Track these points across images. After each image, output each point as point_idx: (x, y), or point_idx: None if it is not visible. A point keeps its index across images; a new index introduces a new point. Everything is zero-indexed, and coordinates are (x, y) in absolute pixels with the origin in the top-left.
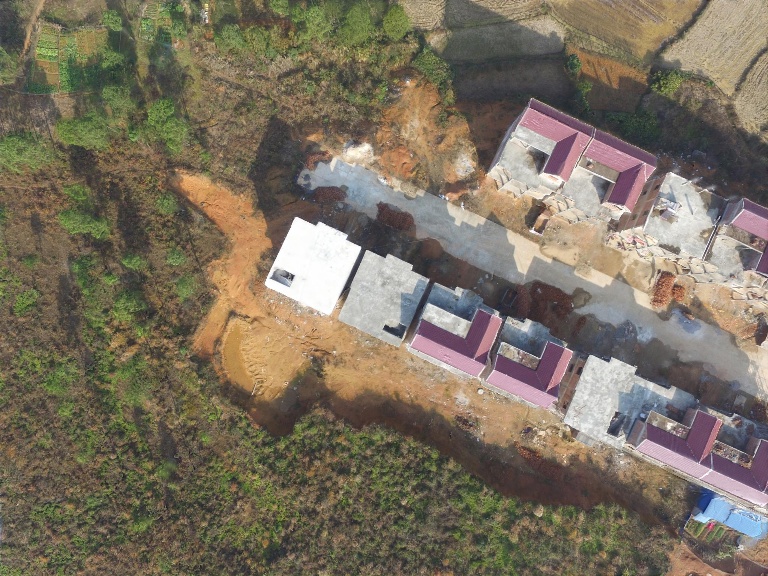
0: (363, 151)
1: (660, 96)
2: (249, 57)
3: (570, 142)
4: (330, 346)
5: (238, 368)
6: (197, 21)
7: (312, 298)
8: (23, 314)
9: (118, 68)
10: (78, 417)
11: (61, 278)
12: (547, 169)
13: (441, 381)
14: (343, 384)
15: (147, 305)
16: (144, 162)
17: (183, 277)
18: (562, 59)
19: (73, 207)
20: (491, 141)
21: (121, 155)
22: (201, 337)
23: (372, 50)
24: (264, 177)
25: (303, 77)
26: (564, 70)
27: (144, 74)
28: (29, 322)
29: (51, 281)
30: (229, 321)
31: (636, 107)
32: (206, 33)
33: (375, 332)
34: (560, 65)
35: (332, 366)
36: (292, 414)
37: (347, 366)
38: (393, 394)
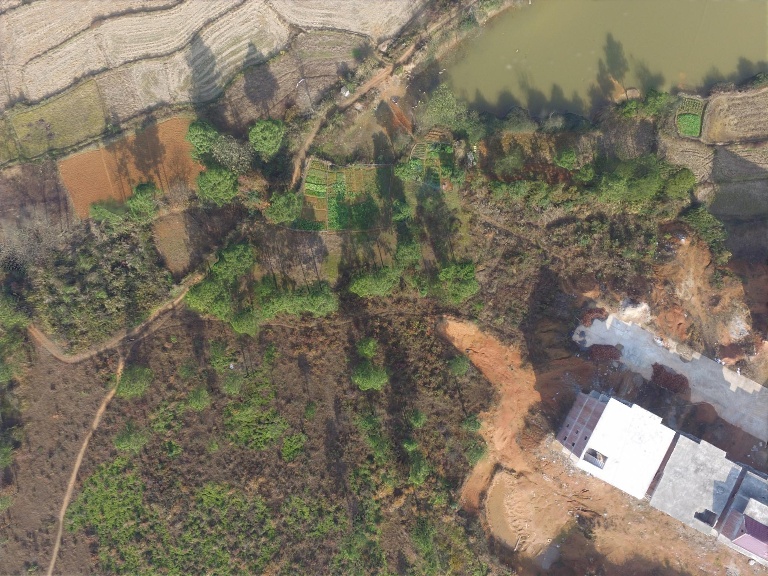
0: (640, 310)
1: None
2: (518, 203)
3: None
4: (601, 508)
5: (501, 522)
6: (466, 163)
7: (625, 482)
8: (291, 459)
9: (385, 207)
10: (346, 569)
11: (328, 422)
12: None
13: (712, 550)
14: (613, 548)
15: (414, 454)
16: (411, 306)
17: (449, 426)
18: None
19: (339, 348)
20: (766, 305)
21: (390, 298)
22: (466, 489)
23: (645, 204)
24: (534, 329)
25: (574, 228)
26: None
27: (412, 215)
28: (298, 467)
29: (318, 425)
30: (495, 474)
31: None
32: (473, 175)
33: (686, 519)
34: None
35: (602, 528)
36: (554, 572)
37: (618, 529)
38: (663, 561)
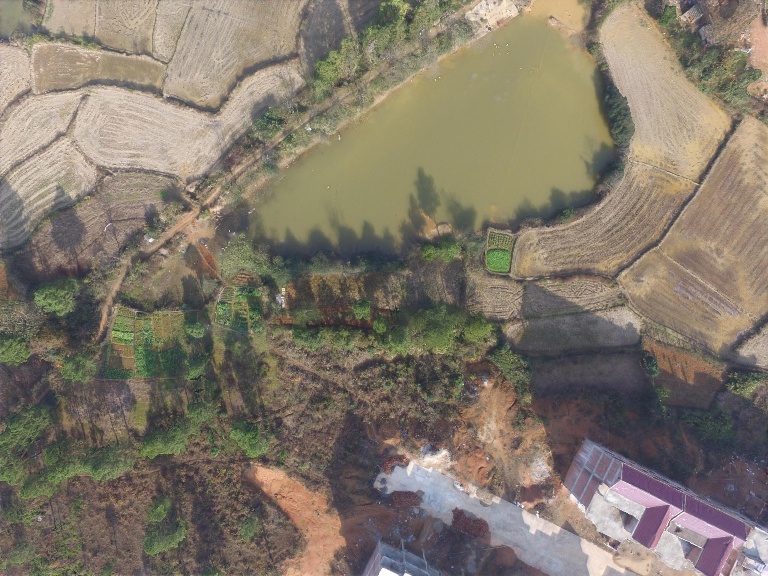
0: (440, 456)
1: (735, 395)
2: (325, 346)
3: (661, 514)
4: None
5: None
6: None
7: None
8: None
9: (194, 353)
10: None
11: (135, 572)
12: (636, 536)
13: None
14: None
15: None
16: (219, 453)
17: (256, 573)
18: (638, 353)
19: (147, 498)
20: (567, 445)
21: (196, 446)
22: None
23: (450, 346)
24: (339, 474)
25: (380, 371)
26: (639, 365)
27: (220, 360)
28: None
29: (125, 575)
30: None
31: (710, 404)
32: (282, 318)
33: None
34: (636, 360)
35: None
36: None
37: None
38: None
